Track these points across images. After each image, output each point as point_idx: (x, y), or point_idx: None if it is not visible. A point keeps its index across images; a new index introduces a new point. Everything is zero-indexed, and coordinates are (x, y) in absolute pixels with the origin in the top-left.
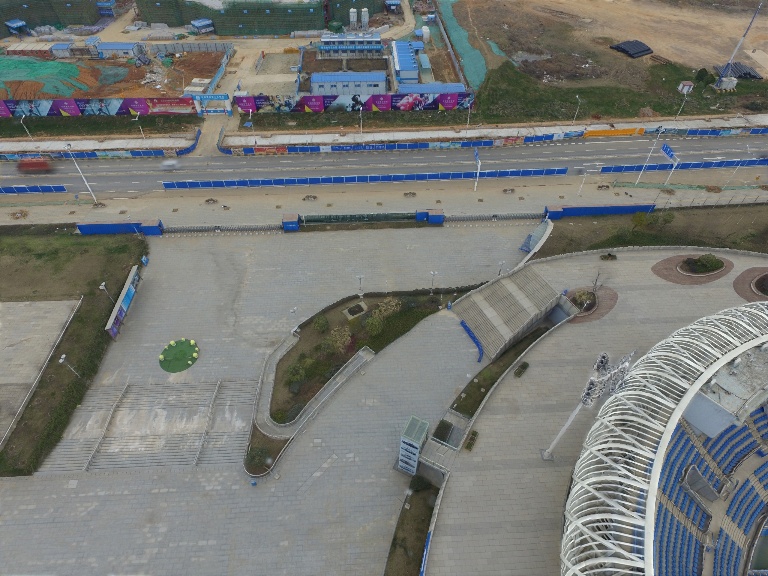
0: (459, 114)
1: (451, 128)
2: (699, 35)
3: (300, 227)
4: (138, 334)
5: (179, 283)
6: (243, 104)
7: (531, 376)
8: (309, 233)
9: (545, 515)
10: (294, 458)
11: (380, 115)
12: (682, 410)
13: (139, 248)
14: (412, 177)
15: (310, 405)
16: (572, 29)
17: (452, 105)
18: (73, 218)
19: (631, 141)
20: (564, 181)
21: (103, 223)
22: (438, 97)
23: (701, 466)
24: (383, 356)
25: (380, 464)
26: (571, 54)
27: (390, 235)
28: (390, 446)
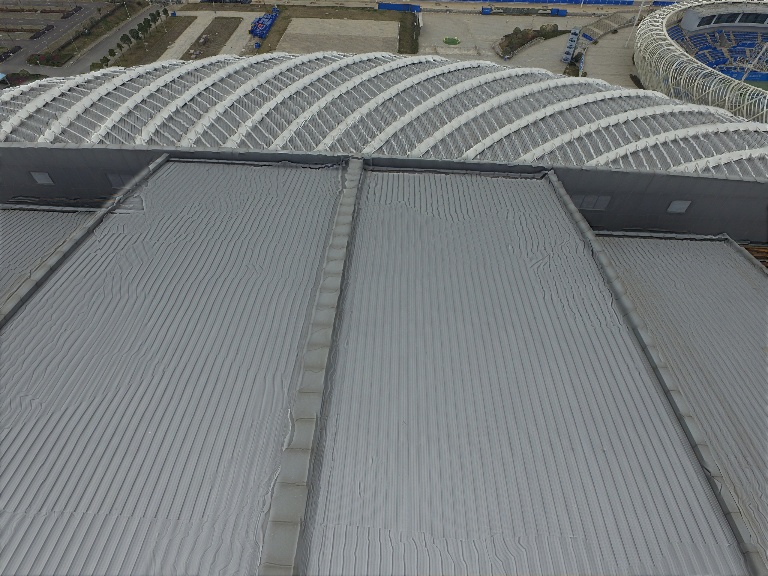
0: None
1: None
2: None
3: (490, 14)
4: (429, 36)
5: (438, 25)
6: None
7: (619, 34)
8: (495, 16)
9: (626, 55)
10: (519, 57)
11: None
12: (680, 9)
13: (412, 14)
14: (545, 1)
15: (519, 50)
16: None
17: None
18: (369, 6)
19: None
20: (631, 8)
21: (392, 3)
22: None
23: None
24: (548, 41)
25: (554, 60)
26: None
27: (538, 18)
28: (557, 57)
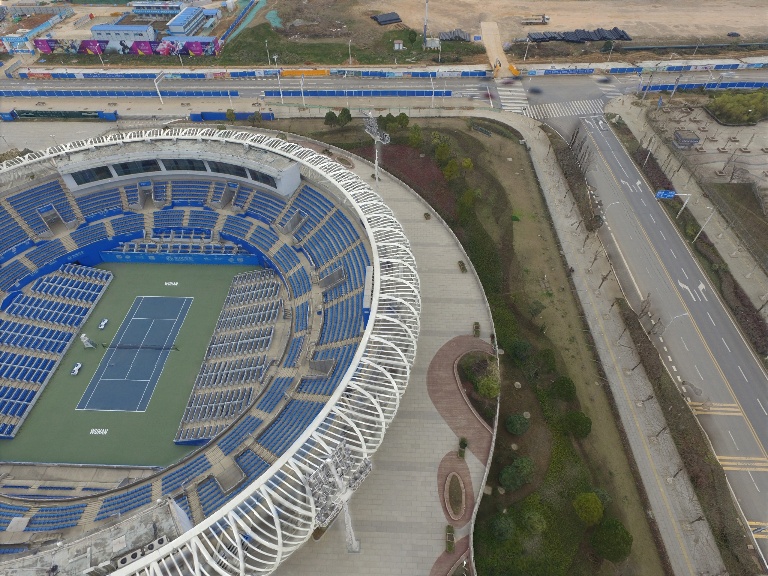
0: (204, 59)
1: (189, 67)
2: (457, 11)
3: (16, 119)
4: None
5: None
6: (40, 46)
7: None
8: (19, 122)
9: None
10: None
11: (142, 57)
12: (26, 163)
13: None
14: (122, 94)
15: None
16: (356, 4)
17: (199, 52)
18: None
19: (316, 79)
20: (235, 101)
21: None
22: (186, 44)
23: (66, 209)
24: None
25: None
26: (332, 21)
27: (73, 125)
28: None
